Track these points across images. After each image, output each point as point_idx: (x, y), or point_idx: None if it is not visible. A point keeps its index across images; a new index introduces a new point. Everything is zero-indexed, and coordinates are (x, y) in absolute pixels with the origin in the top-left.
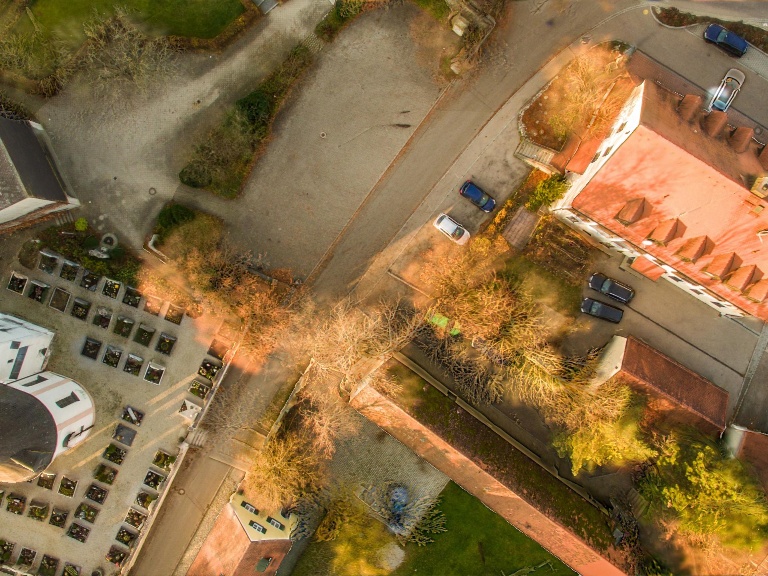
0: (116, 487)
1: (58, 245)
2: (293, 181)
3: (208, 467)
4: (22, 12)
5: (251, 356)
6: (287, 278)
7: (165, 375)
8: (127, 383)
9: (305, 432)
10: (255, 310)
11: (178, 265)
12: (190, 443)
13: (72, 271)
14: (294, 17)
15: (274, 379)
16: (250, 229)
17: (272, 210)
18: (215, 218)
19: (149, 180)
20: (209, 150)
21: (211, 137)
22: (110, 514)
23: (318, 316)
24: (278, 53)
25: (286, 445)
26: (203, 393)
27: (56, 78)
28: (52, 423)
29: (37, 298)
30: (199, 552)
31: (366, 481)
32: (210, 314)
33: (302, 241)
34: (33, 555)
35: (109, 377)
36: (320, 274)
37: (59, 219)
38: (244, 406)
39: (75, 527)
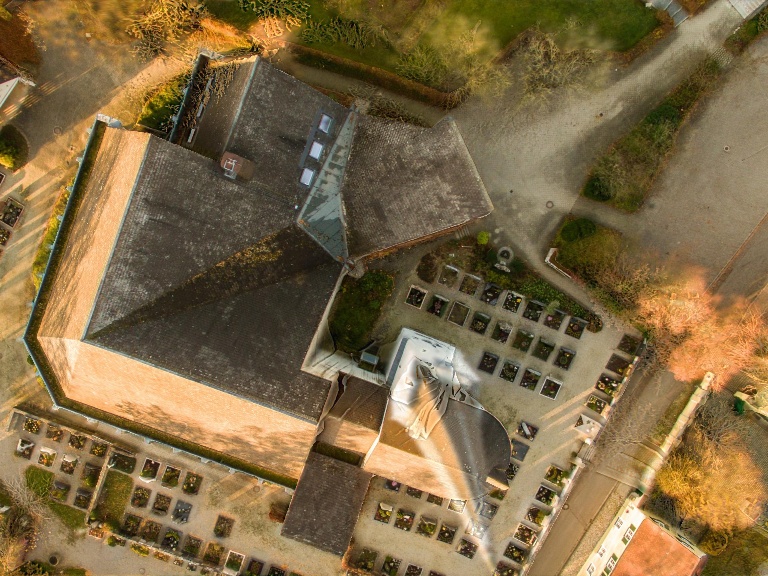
0: (506, 502)
1: (459, 259)
2: (694, 195)
3: (594, 482)
4: (428, 24)
5: (644, 370)
6: (684, 292)
7: (561, 389)
8: (522, 398)
9: (698, 446)
10: (655, 324)
11: (577, 279)
12: (582, 458)
13: (472, 285)
14: (703, 30)
15: (667, 393)
16: (649, 243)
17: (671, 224)
18: (615, 232)
19: (547, 193)
20: (613, 163)
21: (616, 150)
22: (499, 530)
23: (725, 330)
24: (685, 66)
25: (683, 460)
26: (600, 408)
27: (463, 91)
28: (507, 440)
29: (436, 312)
30: (615, 568)
31: (751, 495)
32: (610, 328)
33: (701, 255)
34: (419, 572)
35: (504, 392)
36: (718, 288)
37: (458, 232)
38: (634, 420)
39: (464, 543)
